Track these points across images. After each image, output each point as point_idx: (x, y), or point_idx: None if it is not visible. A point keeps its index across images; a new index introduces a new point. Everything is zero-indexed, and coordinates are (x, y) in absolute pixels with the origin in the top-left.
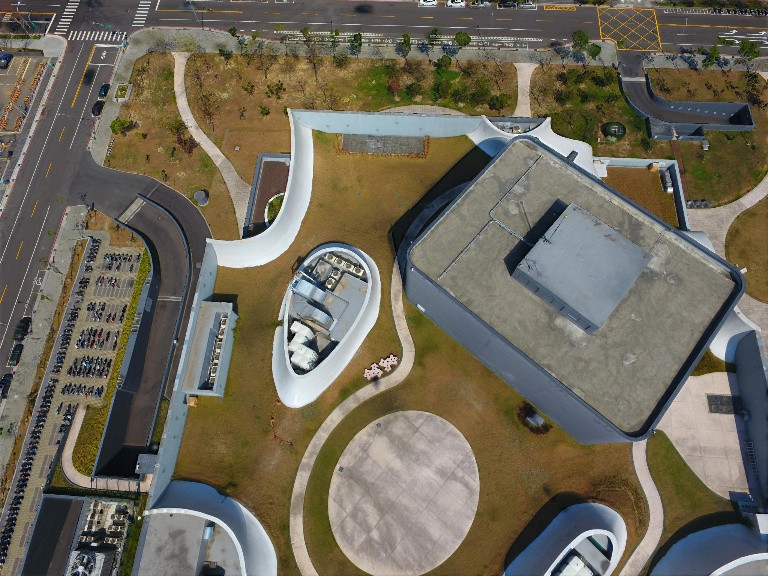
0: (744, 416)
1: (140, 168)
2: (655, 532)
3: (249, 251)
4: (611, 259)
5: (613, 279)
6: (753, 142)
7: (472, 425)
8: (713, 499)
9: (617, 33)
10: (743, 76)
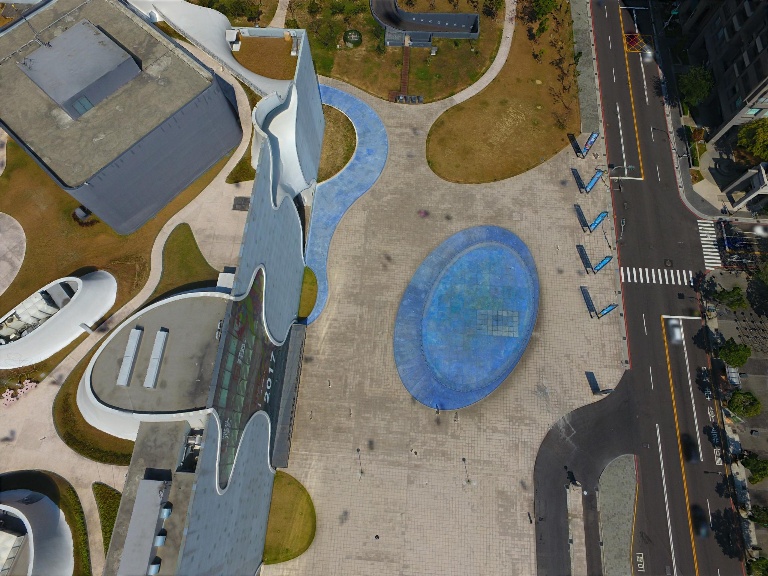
0: None
1: None
2: (146, 293)
3: None
4: (95, 58)
5: (88, 72)
6: (478, 48)
7: (33, 221)
8: (208, 272)
9: None
10: None
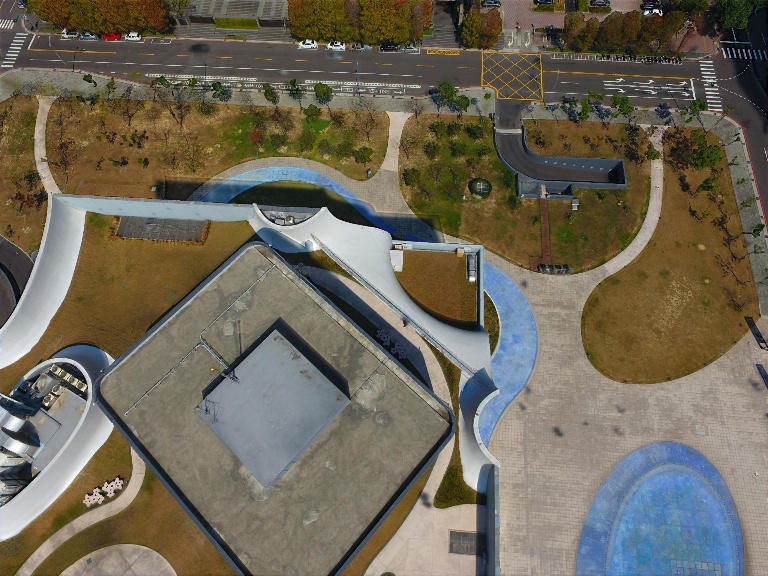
0: (483, 559)
1: None
2: None
3: None
4: (300, 401)
5: (295, 427)
6: (625, 202)
7: (189, 563)
8: None
9: (499, 80)
10: (623, 129)
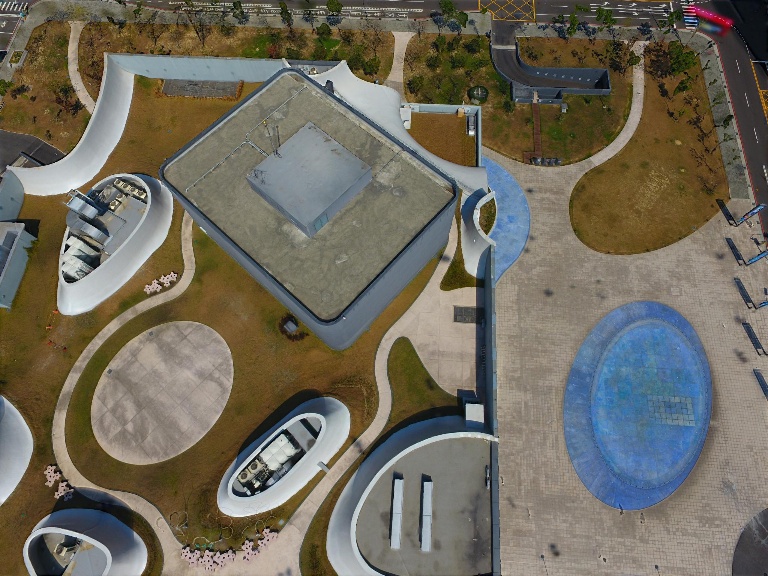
0: None
1: (26, 128)
2: (380, 423)
3: (50, 179)
4: (332, 170)
5: (329, 186)
6: (610, 105)
7: (236, 333)
8: (441, 396)
9: (495, 4)
10: (608, 44)
